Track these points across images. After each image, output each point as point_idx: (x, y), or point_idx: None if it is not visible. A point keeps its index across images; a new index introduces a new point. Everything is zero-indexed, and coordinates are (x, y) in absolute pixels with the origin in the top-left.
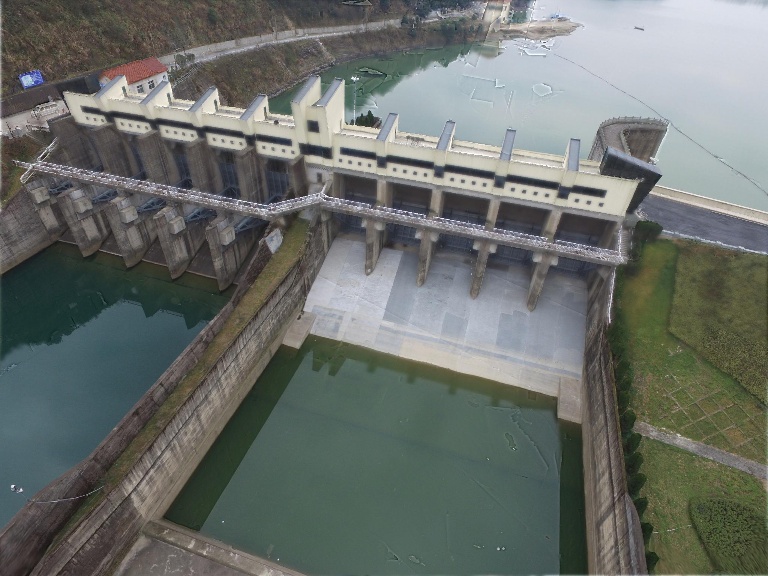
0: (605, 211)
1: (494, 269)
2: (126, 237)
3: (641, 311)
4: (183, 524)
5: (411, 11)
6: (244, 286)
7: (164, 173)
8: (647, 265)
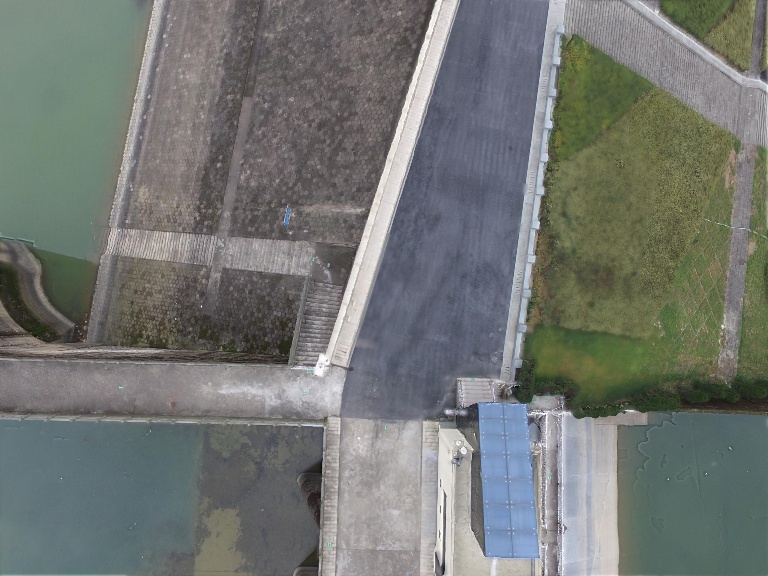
0: None
1: None
2: None
3: (613, 370)
4: None
5: None
6: None
7: None
8: None
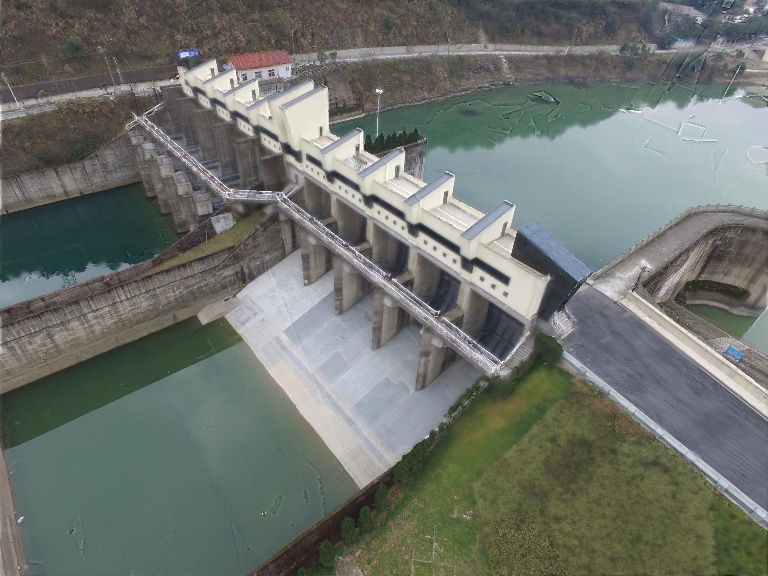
0: (510, 304)
1: (420, 329)
2: (163, 188)
3: (471, 445)
4: (2, 410)
5: (638, 38)
6: (171, 252)
7: None
8: (521, 393)
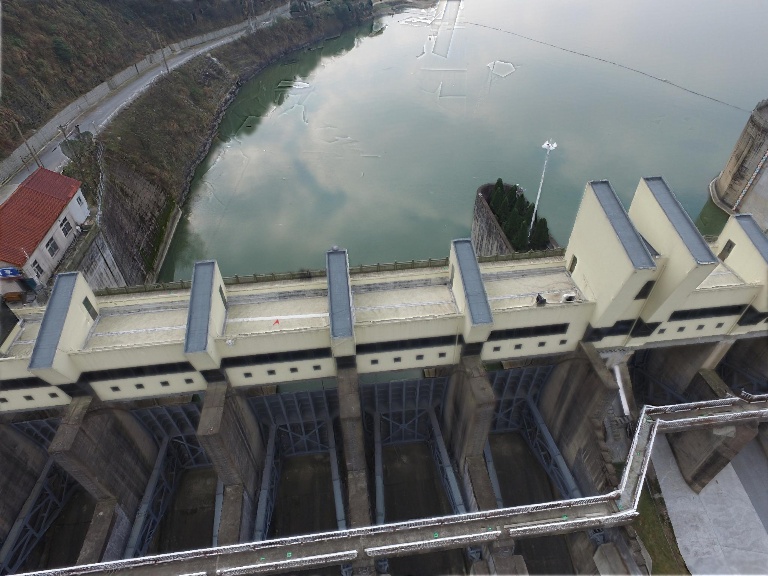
0: None
1: None
2: None
3: None
4: None
5: None
6: None
7: (246, 450)
8: None
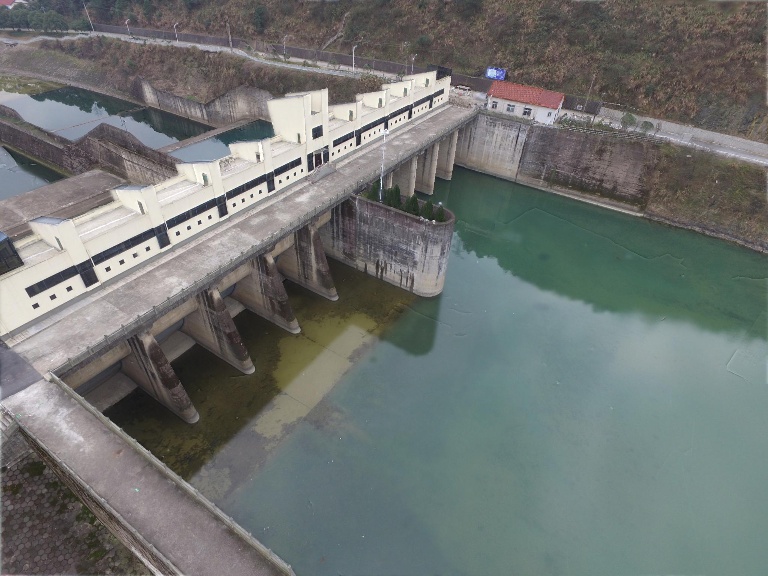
0: None
1: None
2: None
3: None
4: None
5: None
6: None
7: None
8: None
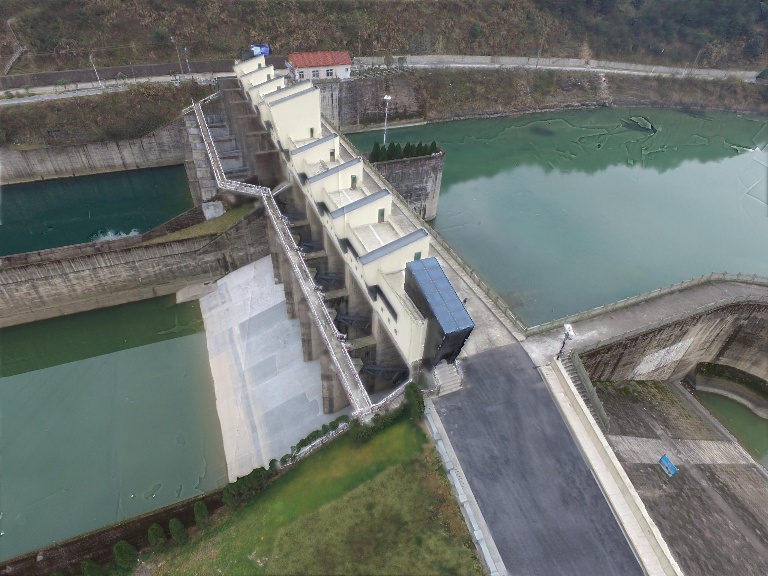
0: (399, 344)
1: None
2: None
3: (306, 486)
4: None
5: None
6: (161, 230)
7: None
8: (374, 445)
